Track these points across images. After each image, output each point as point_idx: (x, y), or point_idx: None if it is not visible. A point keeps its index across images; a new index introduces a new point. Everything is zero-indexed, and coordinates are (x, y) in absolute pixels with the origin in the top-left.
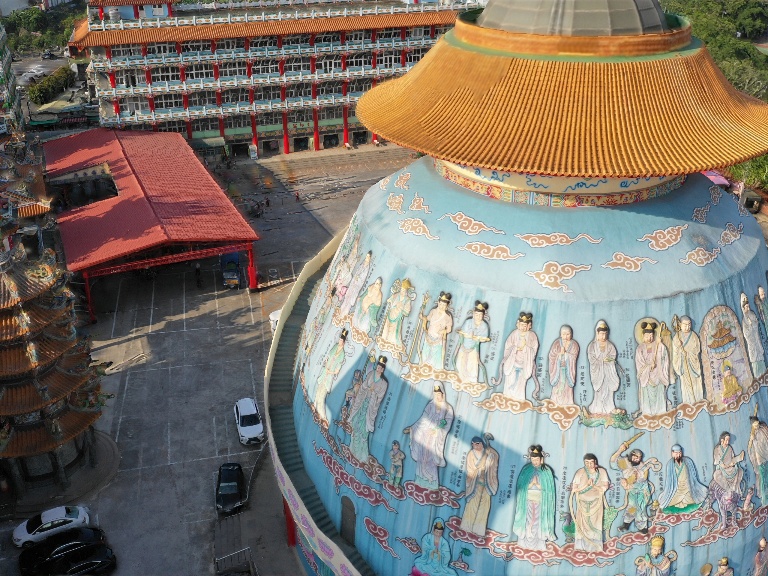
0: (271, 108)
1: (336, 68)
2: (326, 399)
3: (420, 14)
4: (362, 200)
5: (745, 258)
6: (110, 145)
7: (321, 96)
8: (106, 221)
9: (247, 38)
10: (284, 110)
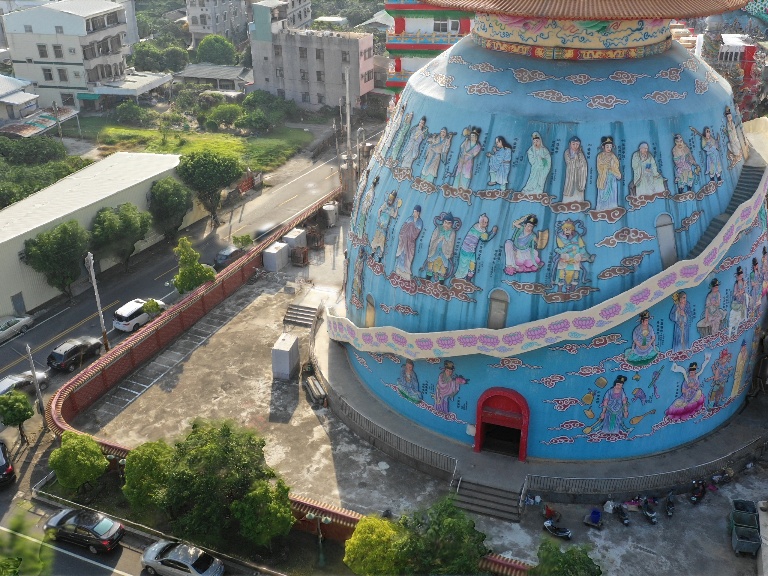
0: None
1: None
2: None
3: None
4: None
5: (424, 90)
6: None
7: None
8: None
9: None
10: None
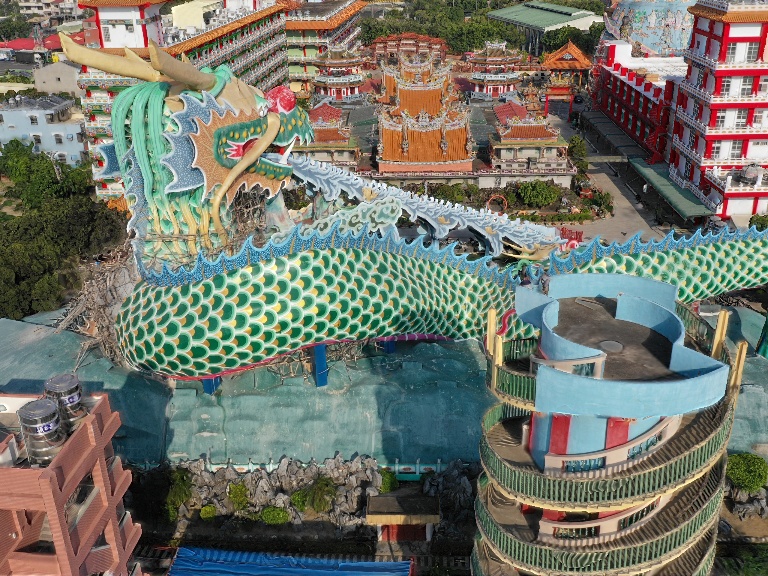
0: None
1: (341, 37)
2: (688, 44)
3: None
4: (654, 7)
5: None
6: None
7: None
8: (472, 85)
9: None
10: None
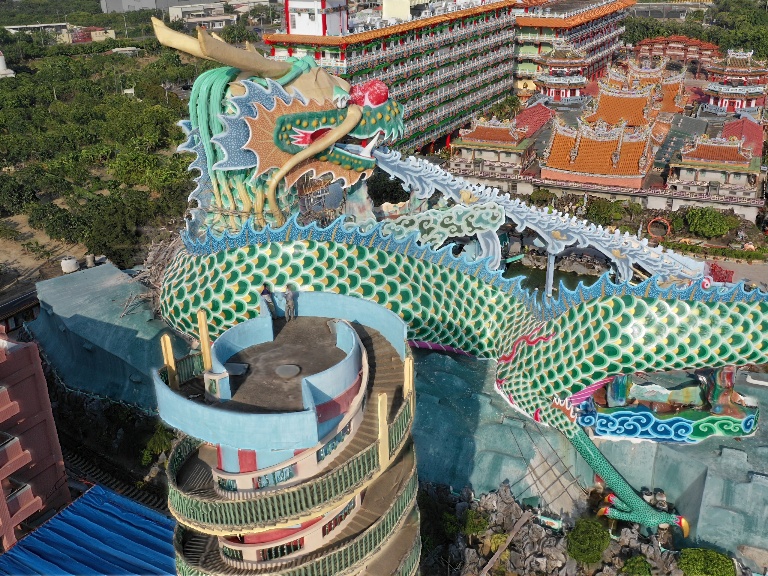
0: (591, 61)
1: None
2: None
3: (618, 2)
4: None
5: None
6: (591, 83)
7: (591, 53)
8: None
9: (595, 18)
10: (593, 61)
